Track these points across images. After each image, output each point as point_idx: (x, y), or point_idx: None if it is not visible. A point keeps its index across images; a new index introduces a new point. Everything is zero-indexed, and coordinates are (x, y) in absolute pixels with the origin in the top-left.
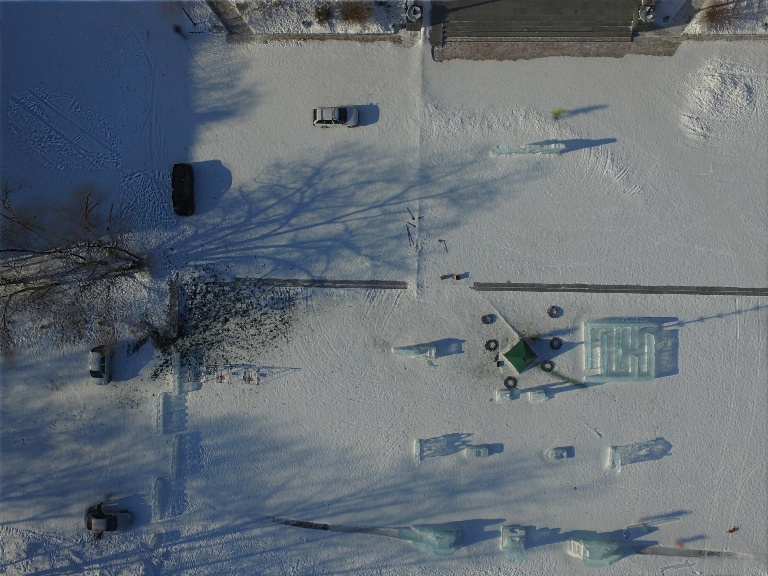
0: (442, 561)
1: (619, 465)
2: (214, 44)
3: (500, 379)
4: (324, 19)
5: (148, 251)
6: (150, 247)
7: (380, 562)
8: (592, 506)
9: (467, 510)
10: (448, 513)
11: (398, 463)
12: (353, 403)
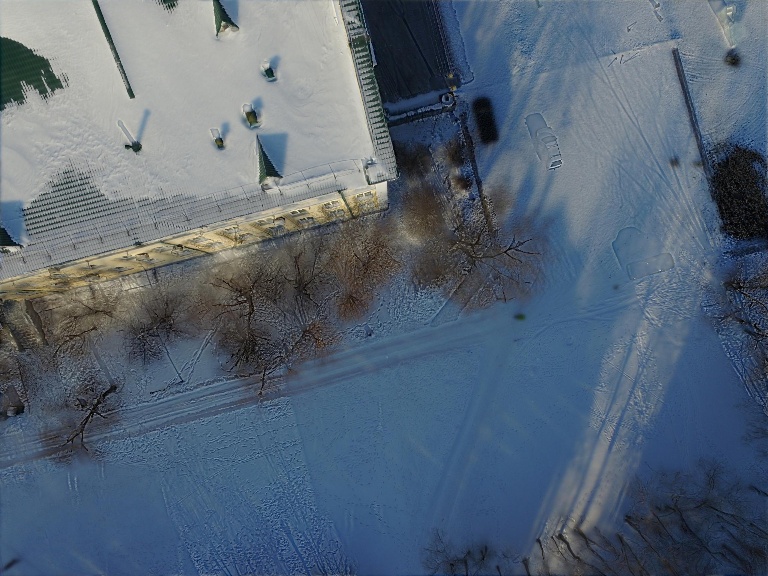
0: None
1: None
2: None
3: None
4: None
5: (715, 283)
6: (708, 284)
7: None
8: None
9: None
10: None
11: None
12: None
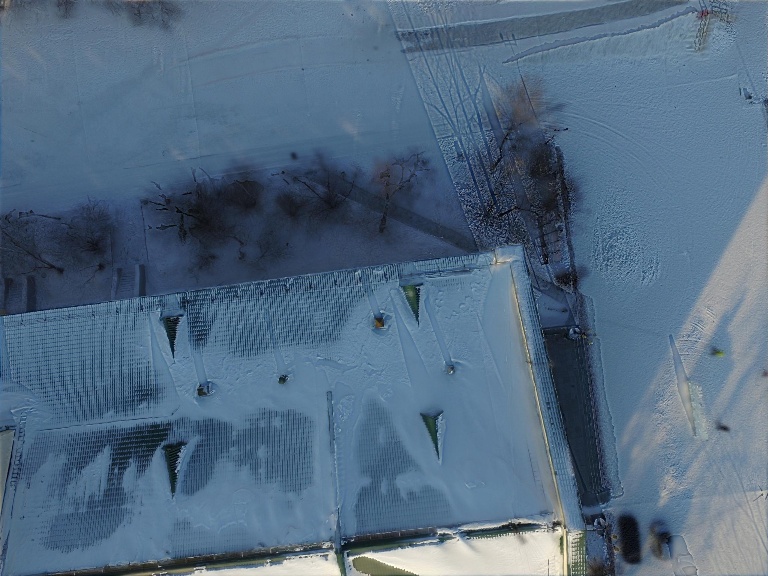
0: None
1: None
2: None
3: None
4: None
5: None
6: None
7: None
8: None
9: None
10: None
11: None
12: None
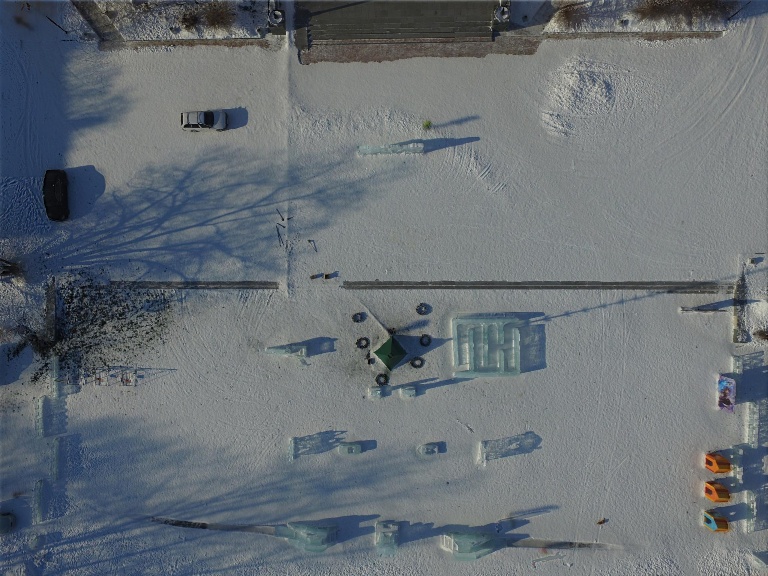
0: (318, 557)
1: (484, 459)
2: (86, 51)
3: (372, 376)
4: (191, 25)
5: (23, 256)
6: (26, 252)
7: (257, 559)
8: (464, 500)
9: (342, 506)
10: (323, 510)
11: (274, 461)
12: (229, 403)
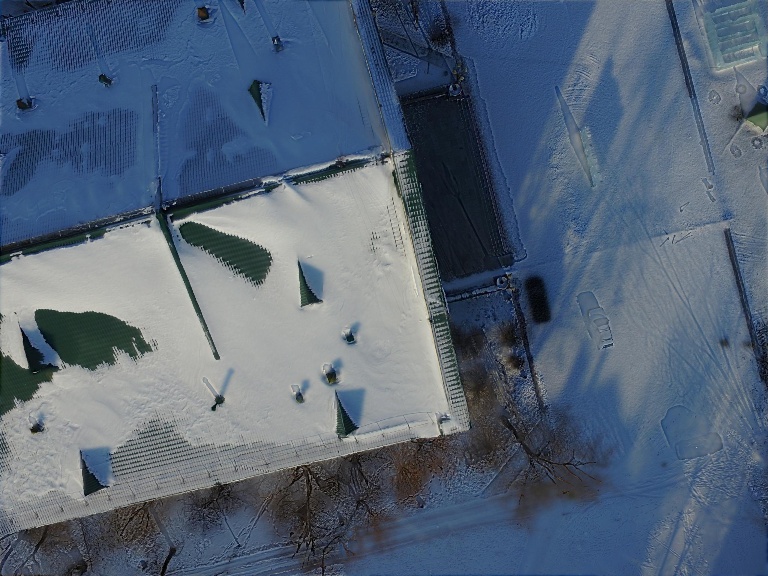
0: None
1: None
2: (559, 453)
3: None
4: (518, 360)
5: (762, 464)
6: (756, 464)
7: None
8: None
9: None
10: None
11: None
12: None
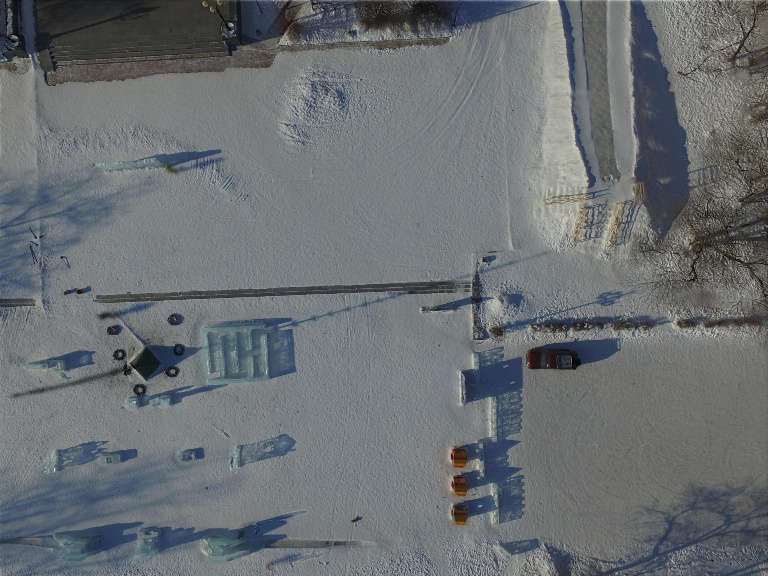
0: (83, 566)
1: None
2: None
3: (129, 387)
4: None
5: None
6: None
7: (25, 571)
8: (223, 504)
9: (107, 515)
10: (89, 519)
11: (40, 474)
12: None
